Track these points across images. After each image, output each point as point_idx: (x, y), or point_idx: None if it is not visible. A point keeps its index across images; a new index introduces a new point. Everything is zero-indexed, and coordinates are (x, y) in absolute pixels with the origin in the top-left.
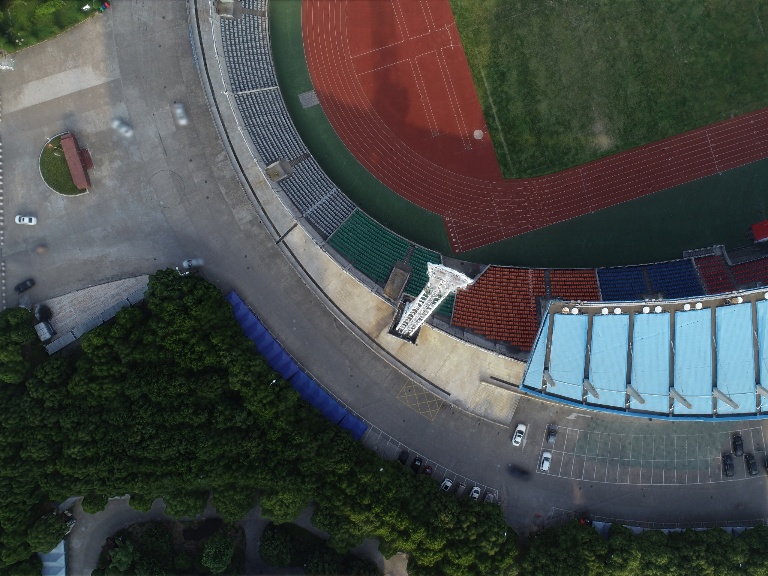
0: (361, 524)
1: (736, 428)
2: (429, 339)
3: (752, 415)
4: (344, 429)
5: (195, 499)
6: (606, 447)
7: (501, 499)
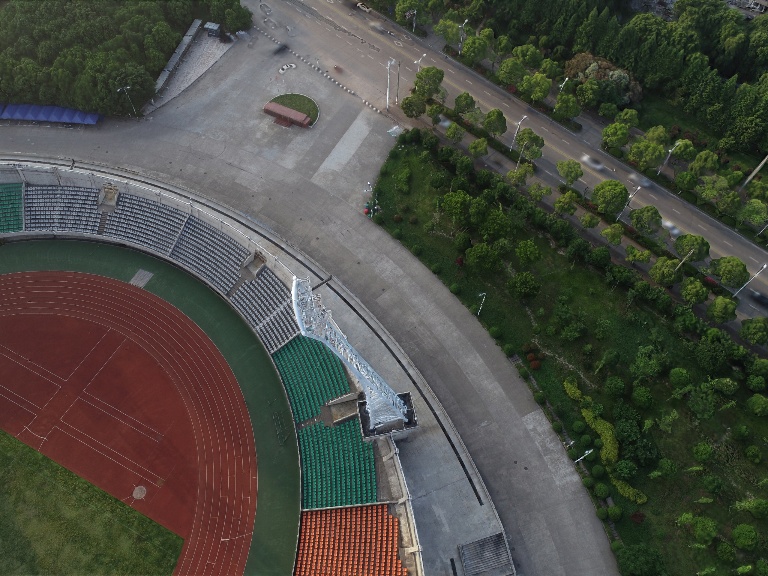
0: None
1: None
2: None
3: None
4: None
5: None
6: None
7: None
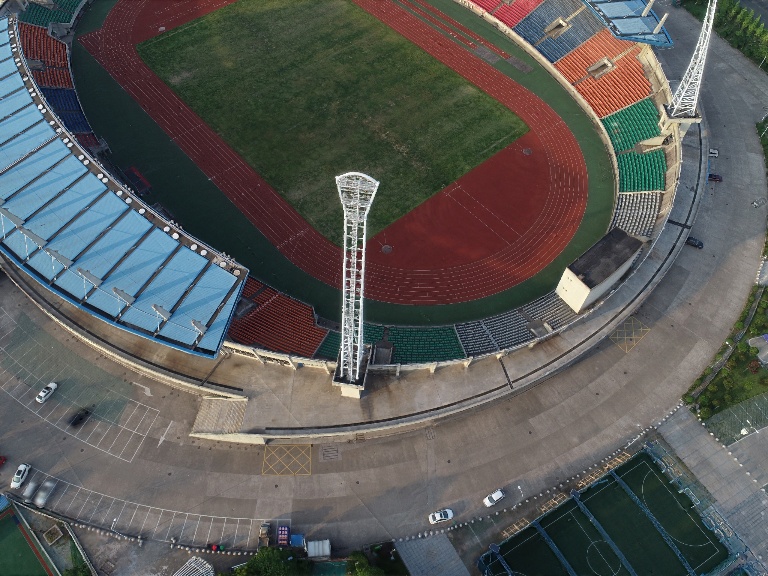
0: None
1: None
2: None
3: None
4: None
5: None
6: None
7: None
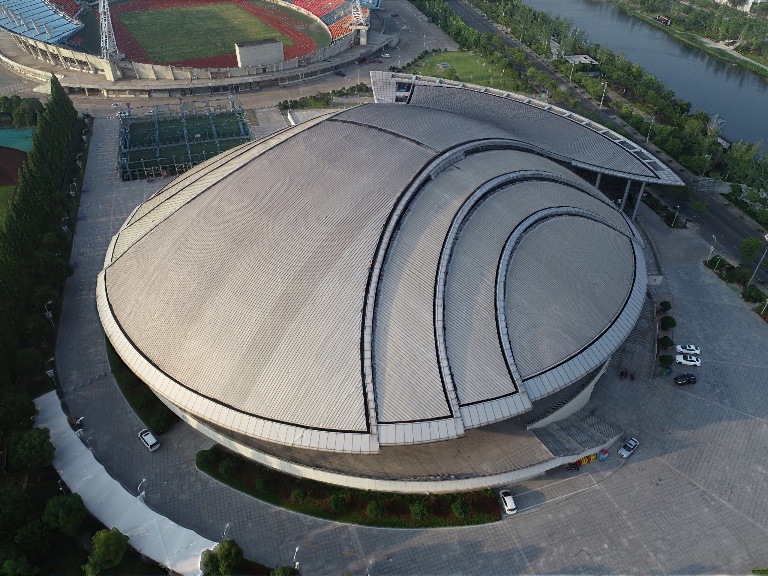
0: None
1: None
2: None
3: None
4: None
5: None
6: None
7: None
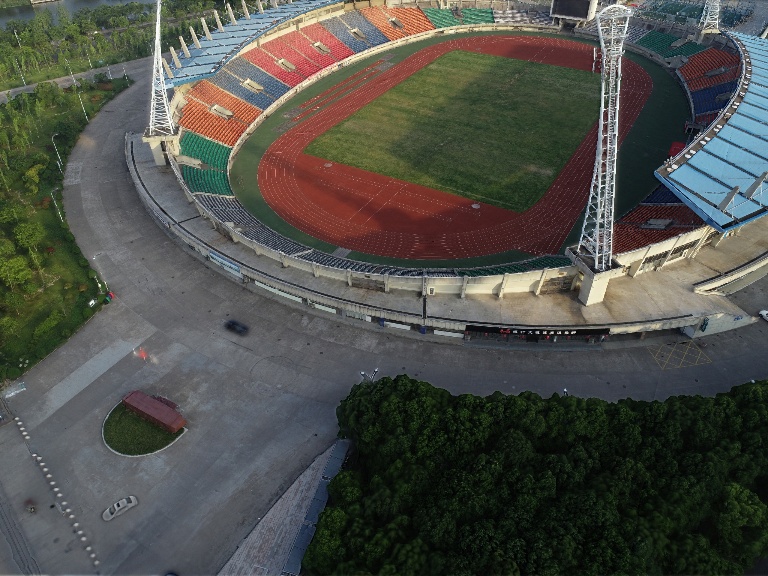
0: None
1: None
2: (620, 295)
3: None
4: None
5: None
6: None
7: None
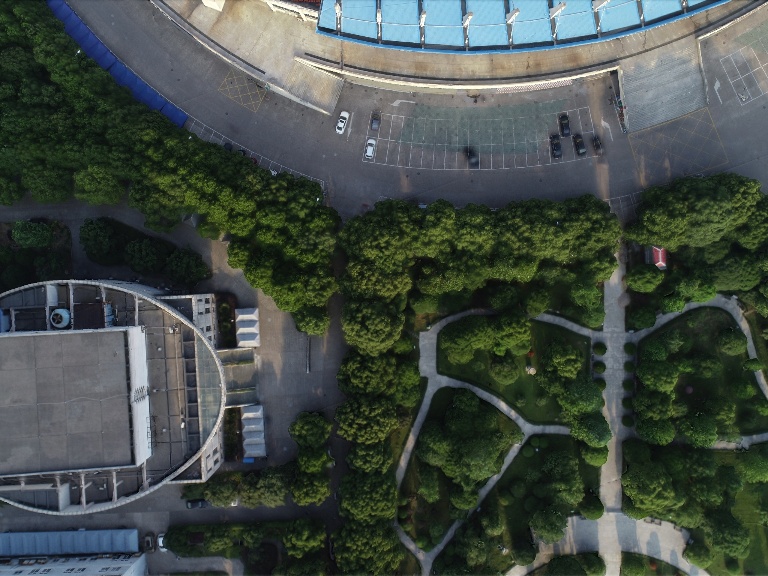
0: (169, 190)
1: (563, 109)
2: (241, 17)
3: (549, 45)
4: (159, 111)
5: (8, 182)
6: (432, 133)
7: (327, 189)
